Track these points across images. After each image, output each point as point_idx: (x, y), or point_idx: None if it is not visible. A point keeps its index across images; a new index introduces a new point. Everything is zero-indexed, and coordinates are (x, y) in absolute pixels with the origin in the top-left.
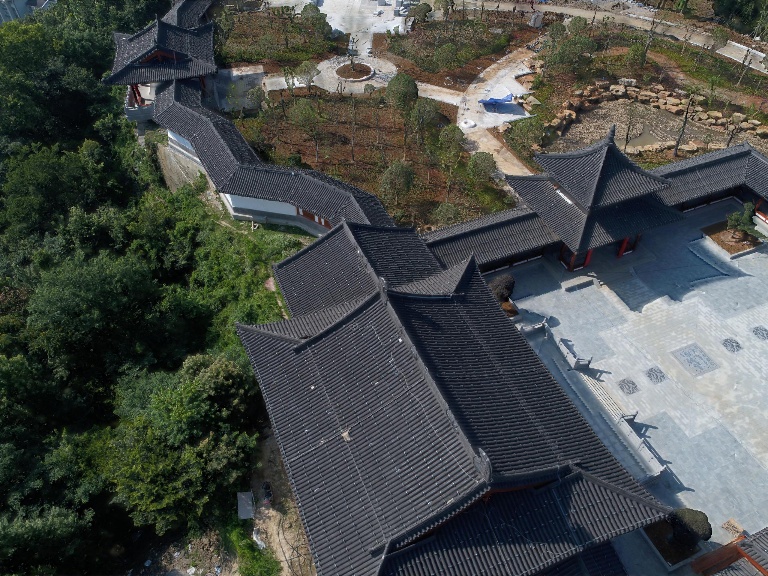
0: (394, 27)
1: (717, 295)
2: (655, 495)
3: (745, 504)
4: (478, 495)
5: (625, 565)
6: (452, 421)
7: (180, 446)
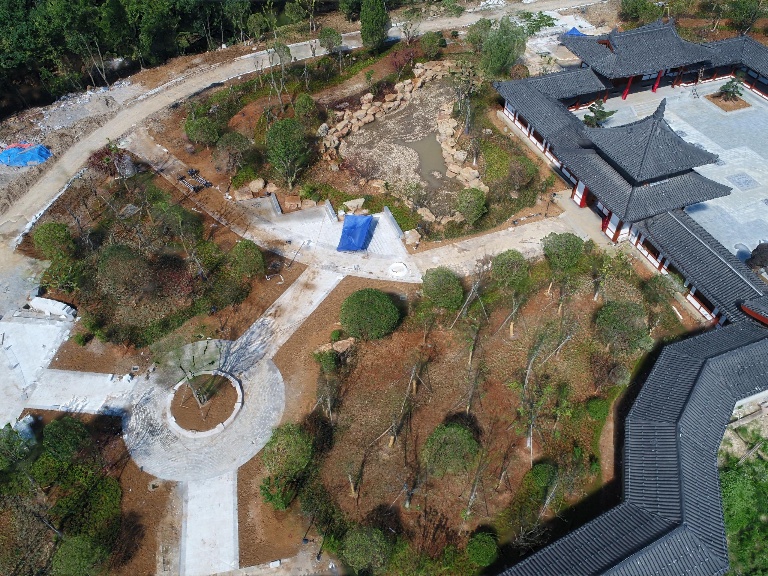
0: None
1: None
2: None
3: None
4: None
5: None
6: None
7: None
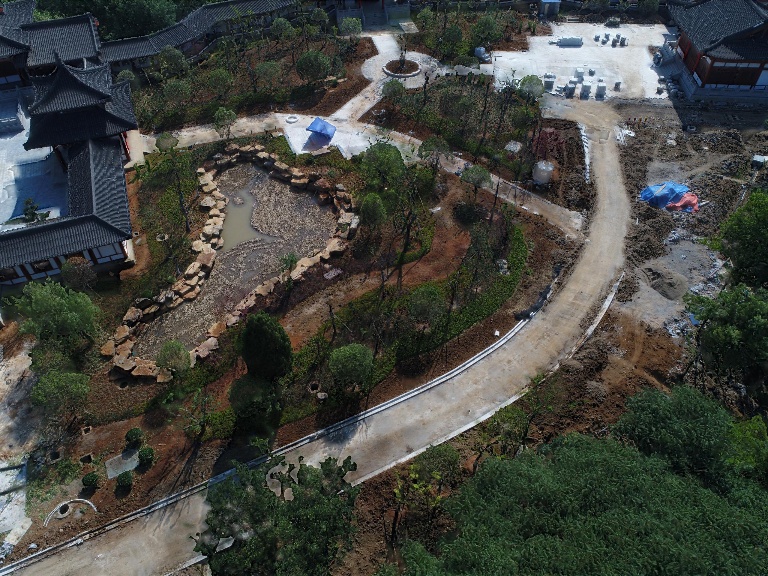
0: None
1: None
2: None
3: None
4: None
5: None
6: None
7: None
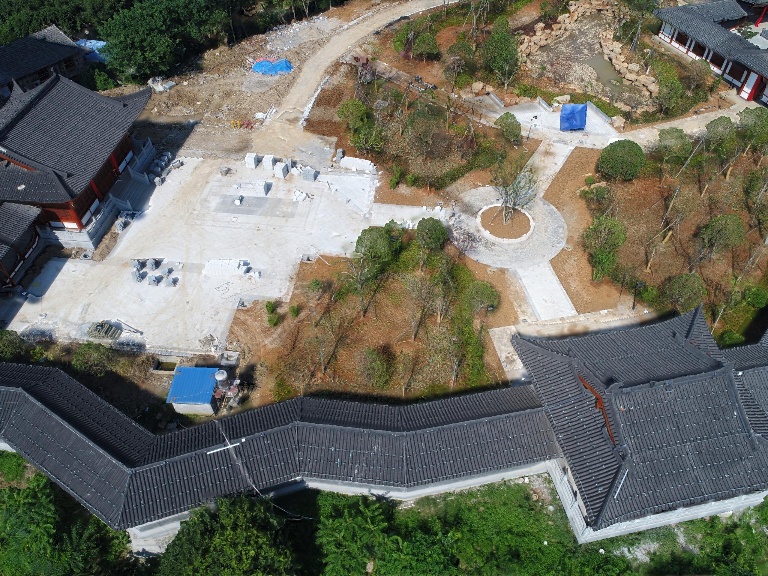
0: None
1: None
2: None
3: None
4: None
5: None
6: None
7: None
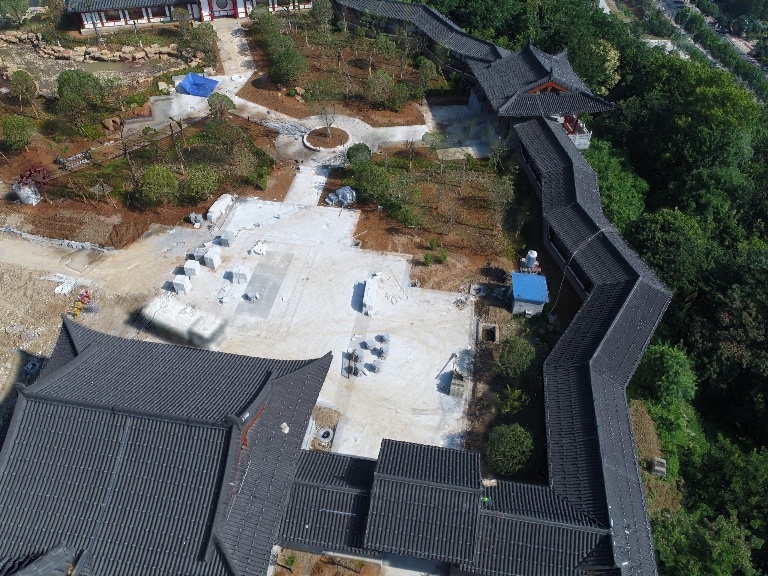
0: None
1: None
2: None
3: None
4: None
5: None
6: None
7: None
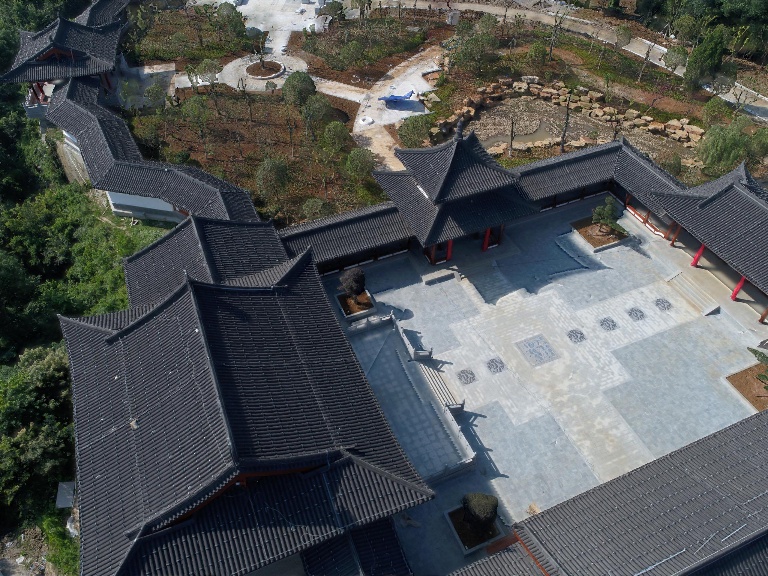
0: (310, 25)
1: (573, 287)
2: (469, 481)
3: (555, 489)
4: (228, 479)
5: (425, 549)
6: (218, 408)
7: (0, 437)
